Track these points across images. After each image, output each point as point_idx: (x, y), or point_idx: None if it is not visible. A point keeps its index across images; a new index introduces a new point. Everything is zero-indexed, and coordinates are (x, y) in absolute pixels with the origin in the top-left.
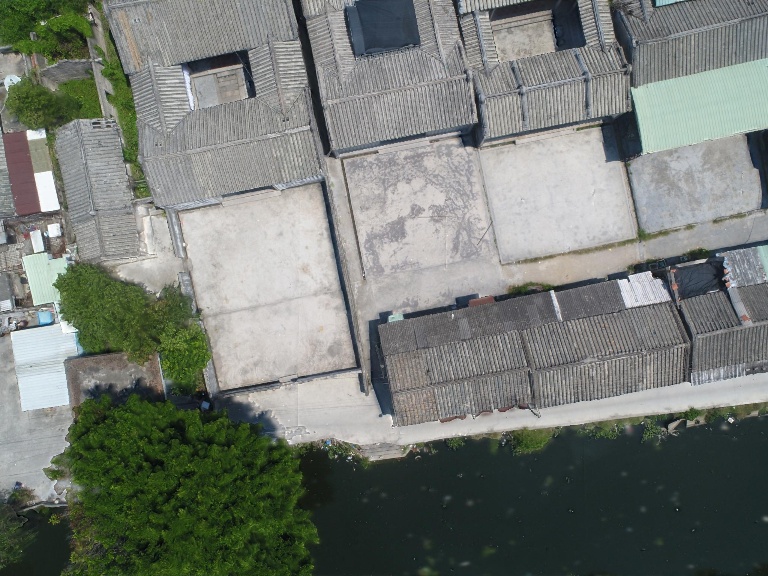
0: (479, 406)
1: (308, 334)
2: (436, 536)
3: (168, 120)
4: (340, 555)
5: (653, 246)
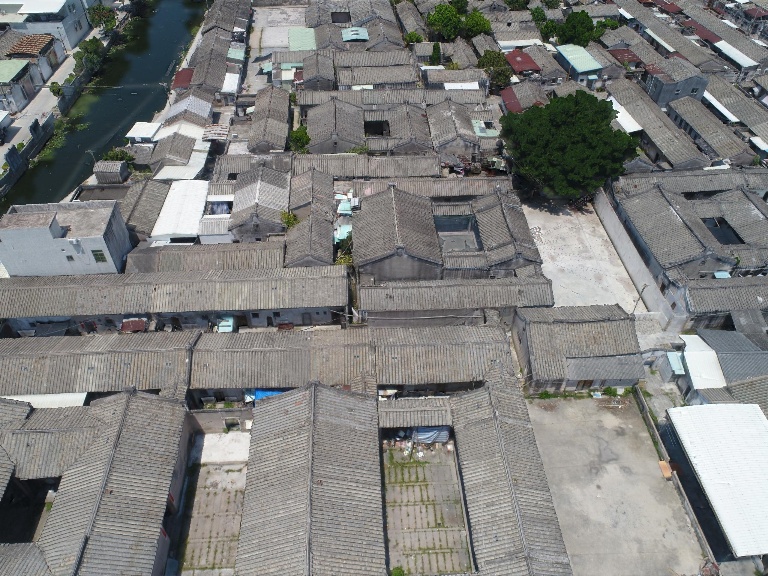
0: None
1: None
2: None
3: None
4: None
5: None
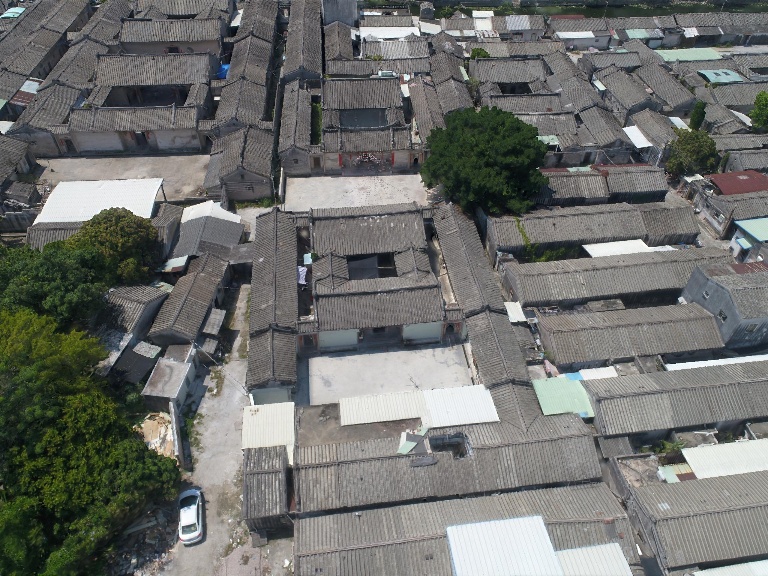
0: None
1: None
2: None
3: None
4: None
5: None
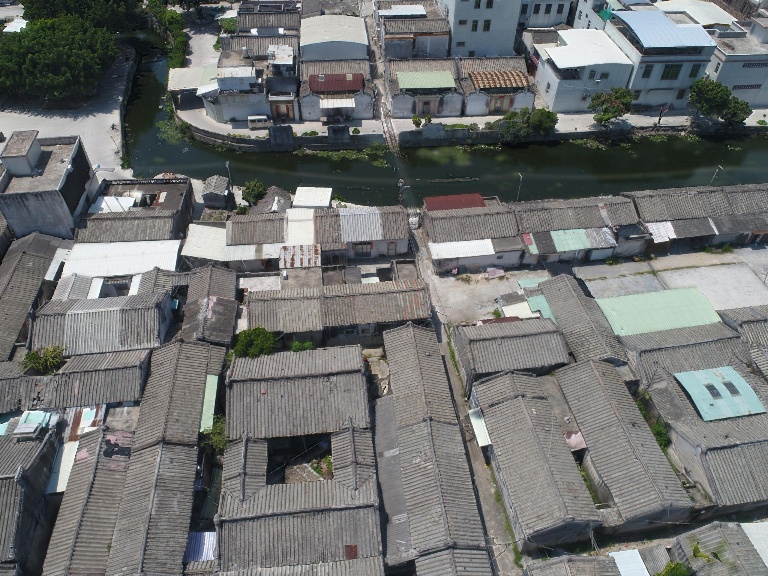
0: None
1: None
2: (715, 167)
3: None
4: (766, 162)
5: (644, 268)
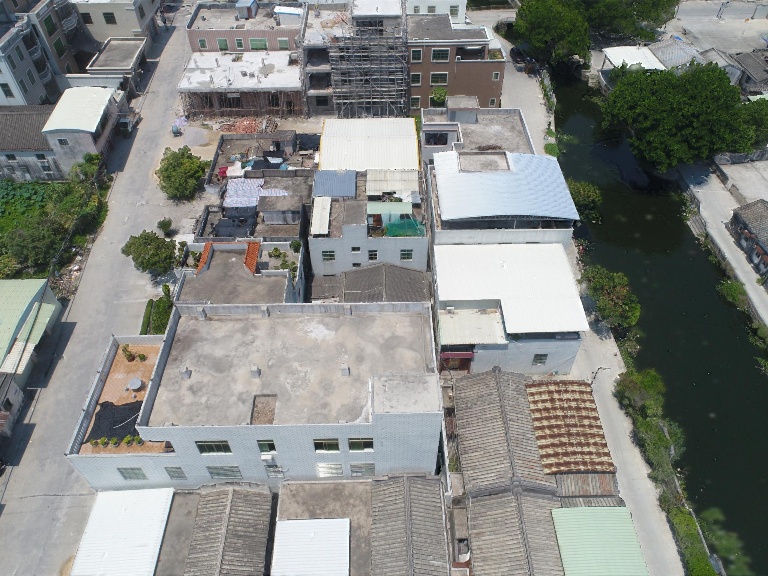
0: (767, 240)
1: (760, 198)
2: (647, 246)
3: None
4: None
5: None
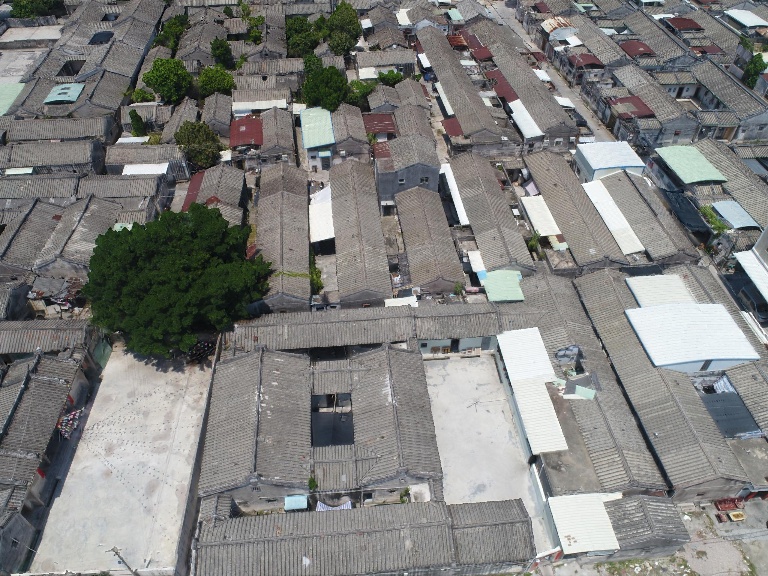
0: None
1: None
2: None
3: (103, 7)
4: None
5: None
